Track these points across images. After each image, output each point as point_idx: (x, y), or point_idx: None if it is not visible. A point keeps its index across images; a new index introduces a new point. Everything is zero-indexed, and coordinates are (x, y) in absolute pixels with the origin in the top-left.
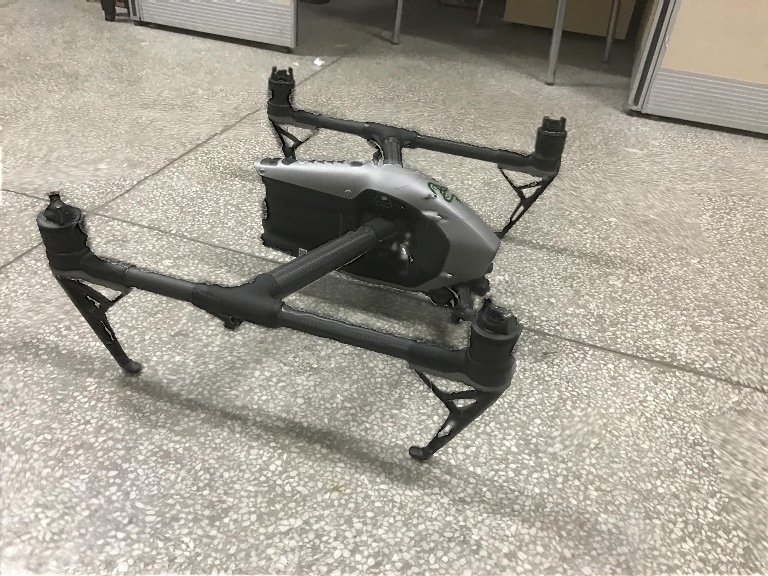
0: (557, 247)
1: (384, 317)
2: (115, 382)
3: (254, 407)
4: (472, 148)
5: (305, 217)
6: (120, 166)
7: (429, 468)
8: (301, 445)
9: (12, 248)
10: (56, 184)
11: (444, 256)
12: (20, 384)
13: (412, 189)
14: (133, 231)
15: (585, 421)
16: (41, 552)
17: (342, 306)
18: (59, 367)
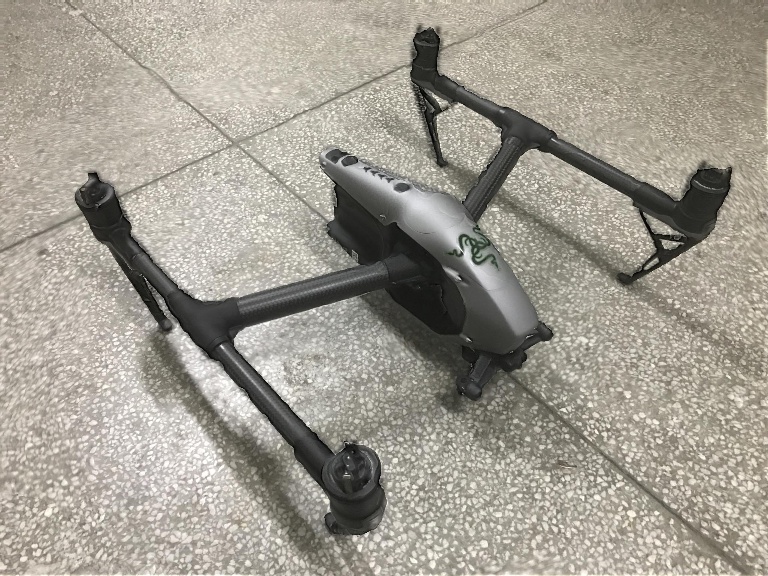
0: (695, 319)
1: (412, 349)
2: (147, 334)
3: (230, 405)
4: (609, 172)
5: (361, 221)
6: (291, 93)
7: (333, 543)
8: (241, 462)
9: (157, 169)
10: (229, 104)
11: (463, 319)
12: (85, 311)
13: (442, 236)
14: (256, 174)
15: (539, 570)
16: (11, 471)
17: (382, 320)
18: (119, 304)
